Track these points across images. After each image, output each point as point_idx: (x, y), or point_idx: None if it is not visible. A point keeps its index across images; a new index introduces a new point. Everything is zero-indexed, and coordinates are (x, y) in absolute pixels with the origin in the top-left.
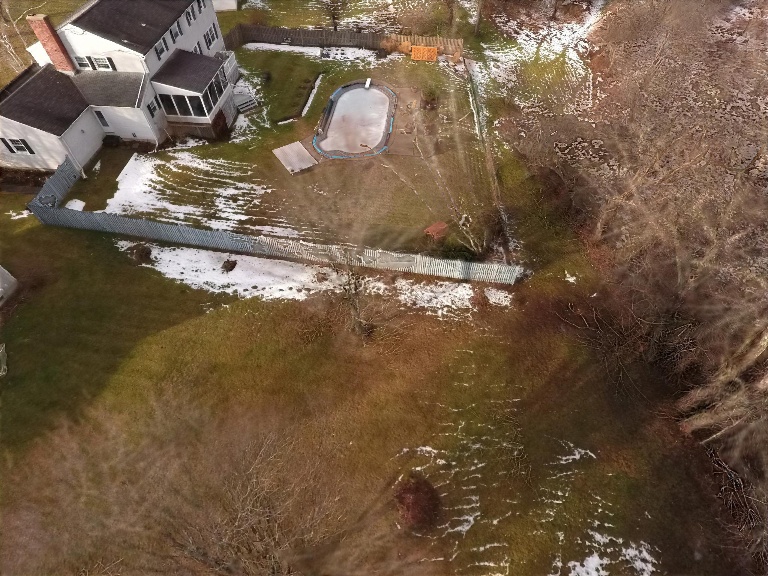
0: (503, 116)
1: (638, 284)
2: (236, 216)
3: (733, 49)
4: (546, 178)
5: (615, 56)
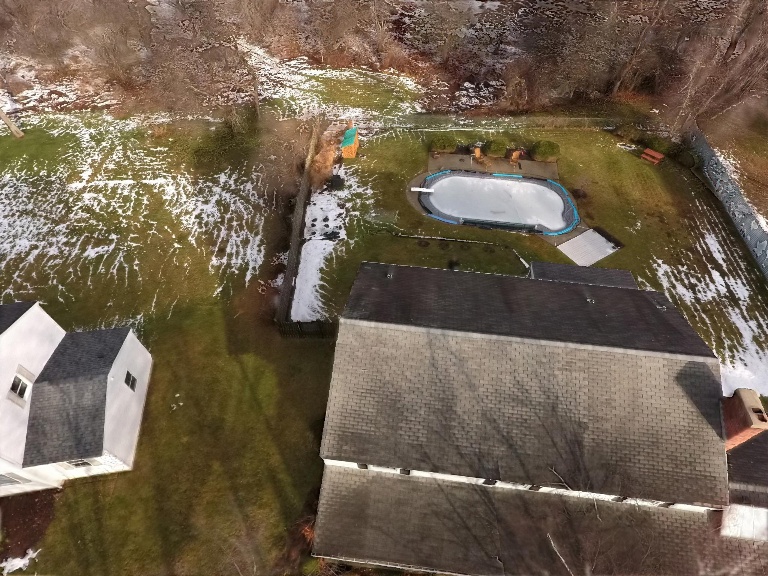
0: (450, 118)
1: (662, 82)
2: (719, 279)
3: (325, 3)
4: (546, 106)
5: (322, 52)
